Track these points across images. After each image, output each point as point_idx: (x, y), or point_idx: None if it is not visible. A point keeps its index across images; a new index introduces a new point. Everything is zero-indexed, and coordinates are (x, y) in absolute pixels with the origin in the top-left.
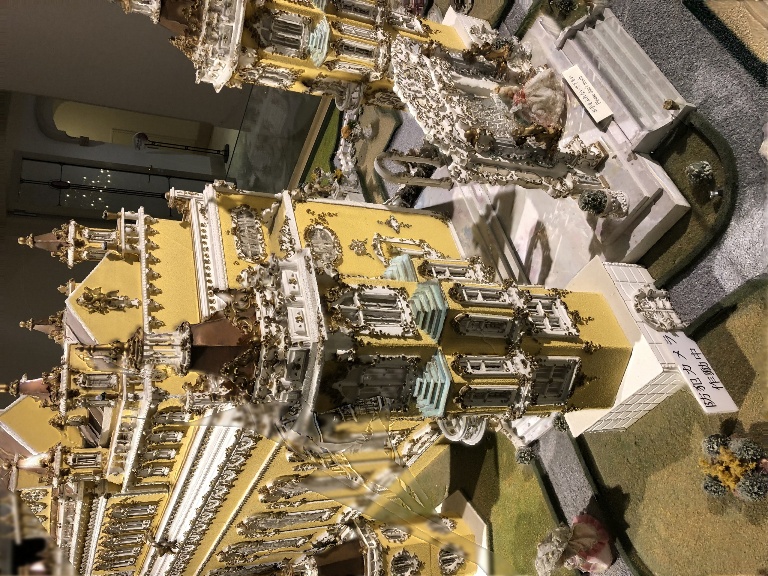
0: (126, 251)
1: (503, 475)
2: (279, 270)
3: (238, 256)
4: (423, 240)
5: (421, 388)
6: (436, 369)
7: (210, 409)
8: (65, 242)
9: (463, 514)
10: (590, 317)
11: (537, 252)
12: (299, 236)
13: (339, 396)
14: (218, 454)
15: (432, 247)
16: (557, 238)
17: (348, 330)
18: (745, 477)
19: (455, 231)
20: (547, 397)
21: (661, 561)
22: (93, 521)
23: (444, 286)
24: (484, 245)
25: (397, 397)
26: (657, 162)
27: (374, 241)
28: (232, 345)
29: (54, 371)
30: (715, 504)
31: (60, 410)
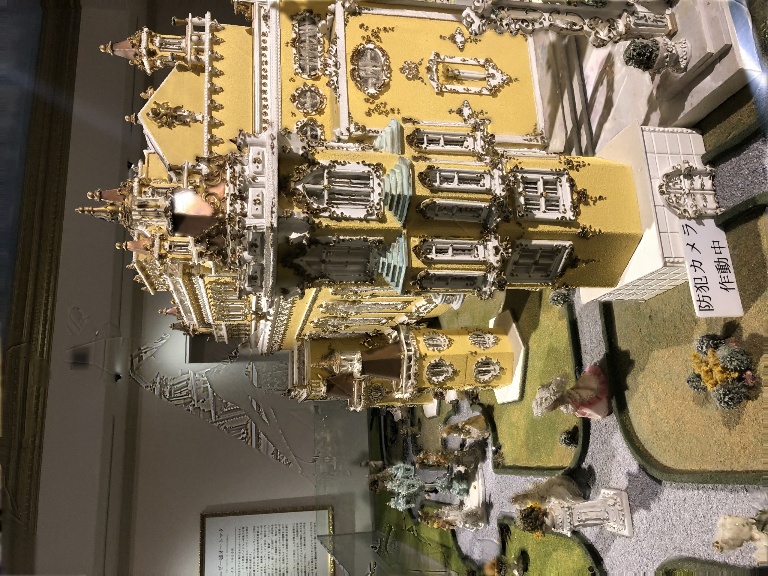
0: (192, 62)
1: (544, 308)
2: (248, 146)
3: (294, 72)
4: (489, 59)
5: (384, 267)
6: (397, 252)
7: None
8: (138, 51)
9: (509, 332)
10: (601, 196)
11: (602, 90)
12: (346, 58)
13: (302, 269)
14: None
15: (499, 68)
16: (622, 79)
17: (303, 214)
18: (722, 384)
19: (534, 46)
20: (533, 276)
21: (645, 427)
22: (199, 290)
23: (417, 167)
24: (555, 70)
25: (364, 270)
26: (744, 1)
27: (429, 63)
28: (208, 215)
29: (128, 184)
30: (698, 395)
31: None
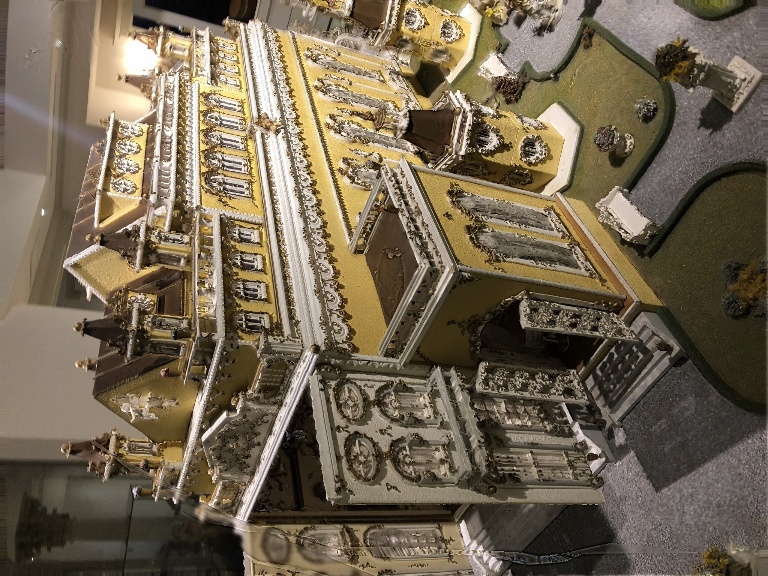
0: None
1: None
2: None
3: None
4: None
5: None
6: None
7: (241, 23)
8: None
9: None
10: None
11: None
12: None
13: None
14: (261, 45)
15: None
16: None
17: None
18: None
19: None
20: None
21: None
22: (191, 110)
23: None
24: None
25: None
26: None
27: None
28: None
29: None
30: None
31: (160, 31)
